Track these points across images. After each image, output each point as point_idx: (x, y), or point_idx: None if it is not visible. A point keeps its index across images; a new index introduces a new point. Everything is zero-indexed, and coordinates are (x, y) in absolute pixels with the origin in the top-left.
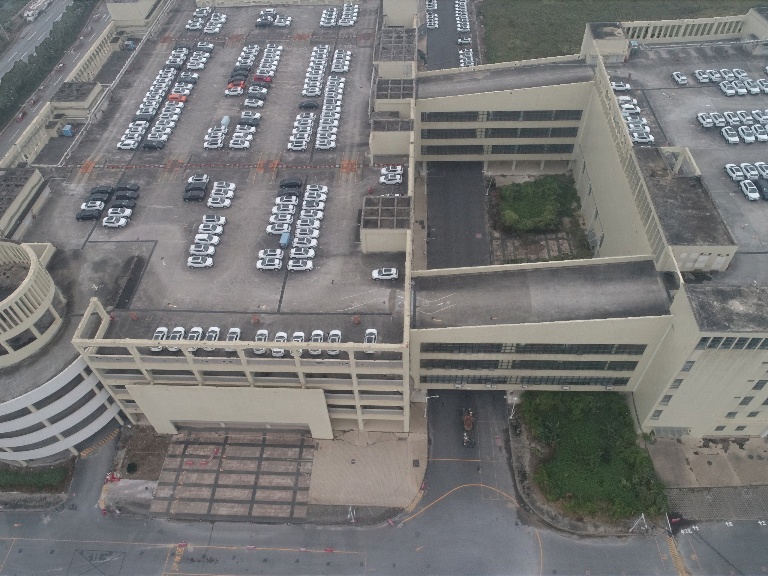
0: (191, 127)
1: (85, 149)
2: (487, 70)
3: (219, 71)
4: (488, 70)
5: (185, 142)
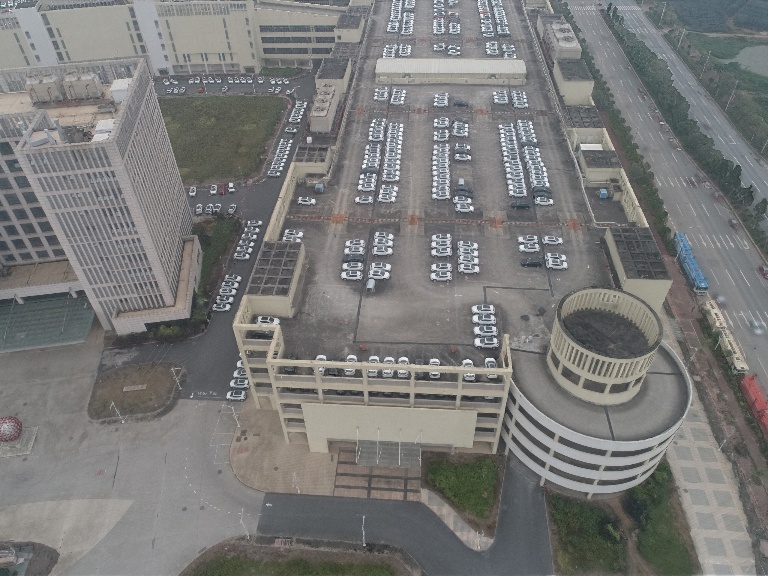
0: (469, 6)
1: (517, 0)
2: (308, 16)
3: (470, 26)
4: (307, 16)
5: (468, 2)
